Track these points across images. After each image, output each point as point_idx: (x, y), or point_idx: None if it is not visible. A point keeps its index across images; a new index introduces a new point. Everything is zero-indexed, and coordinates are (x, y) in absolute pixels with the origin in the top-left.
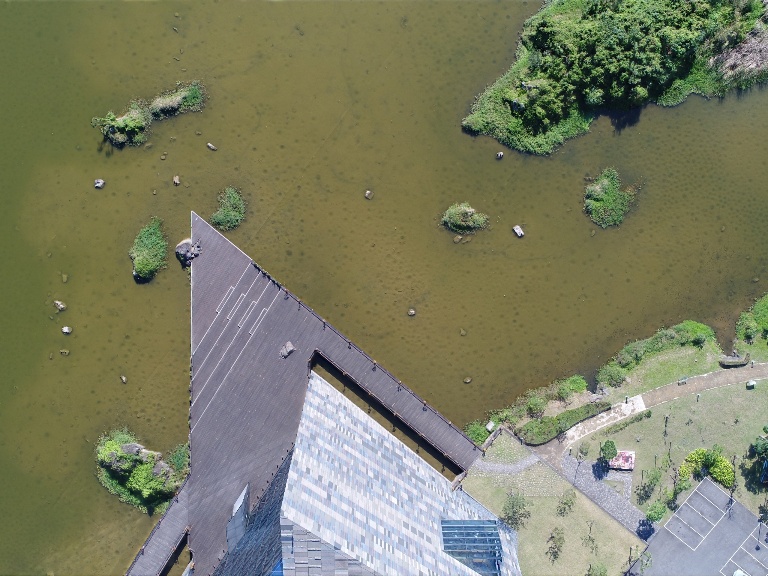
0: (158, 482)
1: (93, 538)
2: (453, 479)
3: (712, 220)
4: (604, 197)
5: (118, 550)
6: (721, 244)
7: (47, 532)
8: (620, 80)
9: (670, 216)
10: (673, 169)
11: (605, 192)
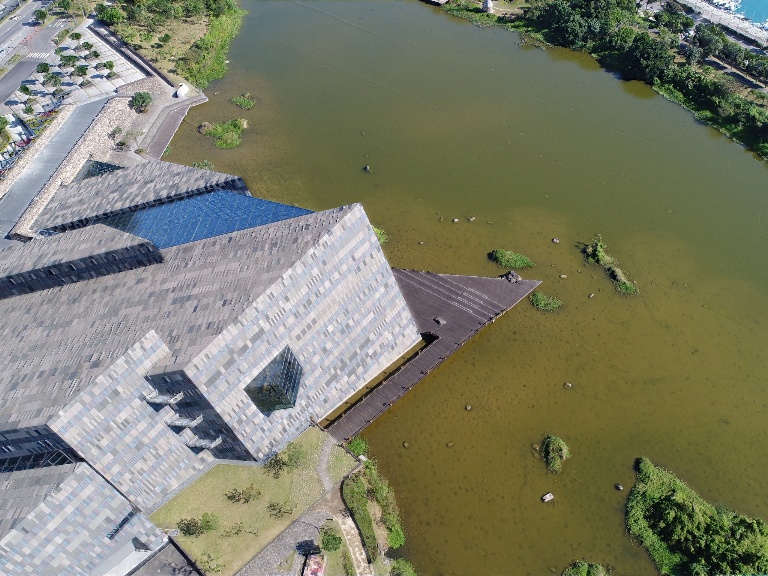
0: None
1: None
2: None
3: None
4: None
5: None
6: None
7: (325, 205)
8: None
9: None
10: None
11: None
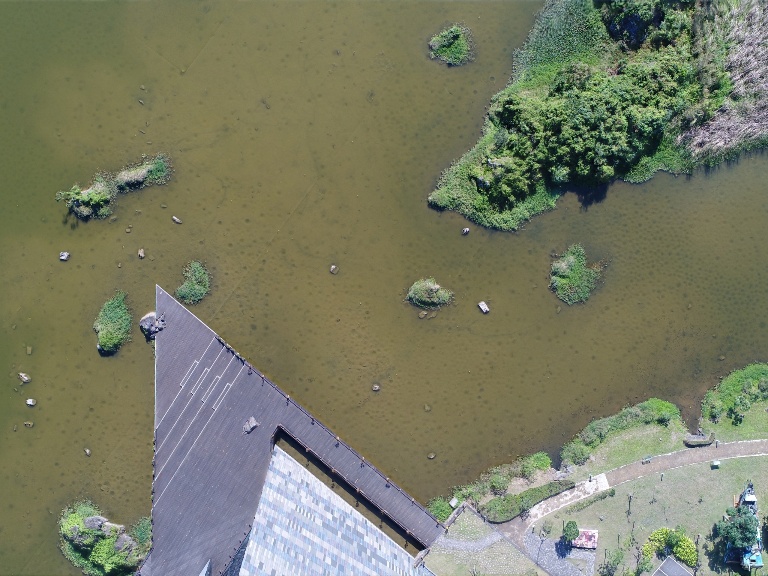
0: (120, 557)
1: None
2: (416, 555)
3: (678, 298)
4: (570, 274)
5: None
6: (687, 322)
7: None
8: (586, 159)
9: (636, 293)
10: (640, 246)
11: (571, 269)
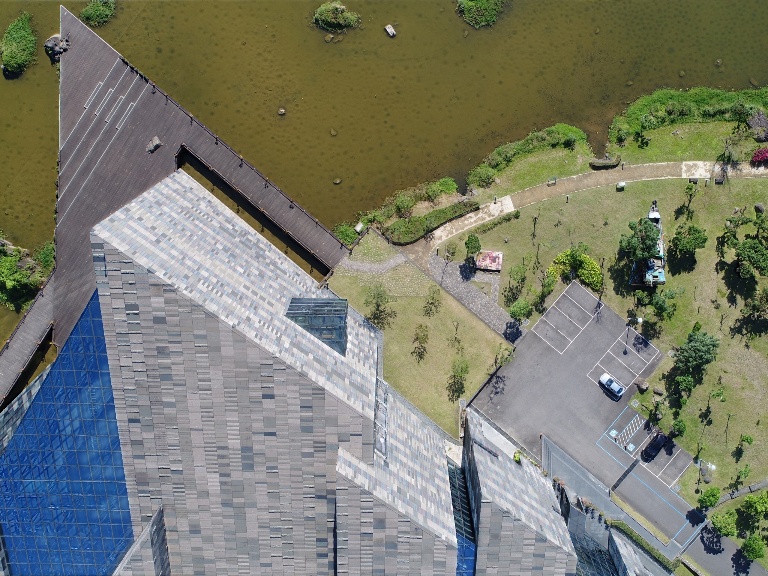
0: (22, 275)
1: None
2: (321, 280)
3: (586, 22)
4: None
5: None
6: (595, 47)
7: None
8: None
9: (544, 18)
10: None
11: None
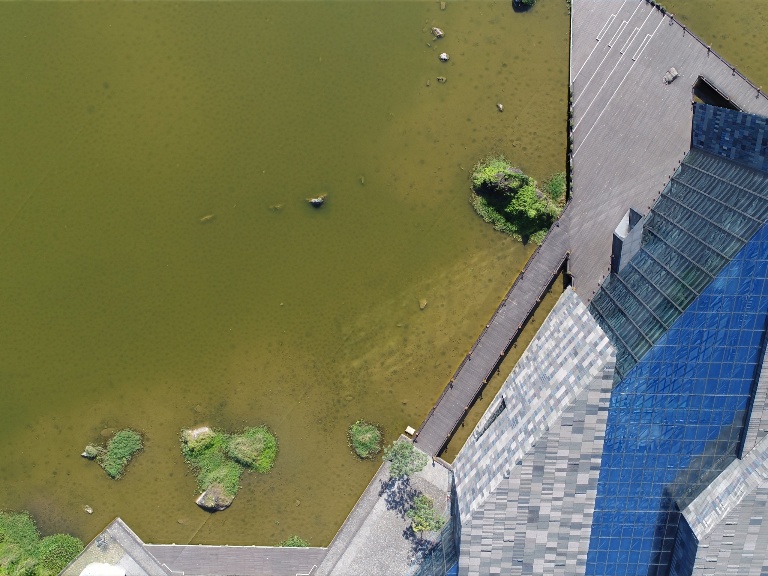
0: (542, 204)
1: (466, 266)
2: None
3: None
4: None
5: (491, 278)
6: None
7: (420, 260)
8: None
9: None
10: None
11: None
